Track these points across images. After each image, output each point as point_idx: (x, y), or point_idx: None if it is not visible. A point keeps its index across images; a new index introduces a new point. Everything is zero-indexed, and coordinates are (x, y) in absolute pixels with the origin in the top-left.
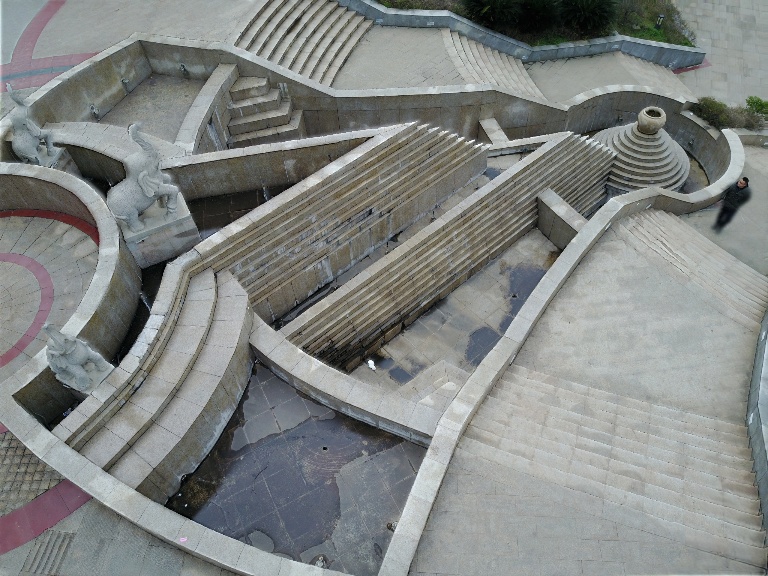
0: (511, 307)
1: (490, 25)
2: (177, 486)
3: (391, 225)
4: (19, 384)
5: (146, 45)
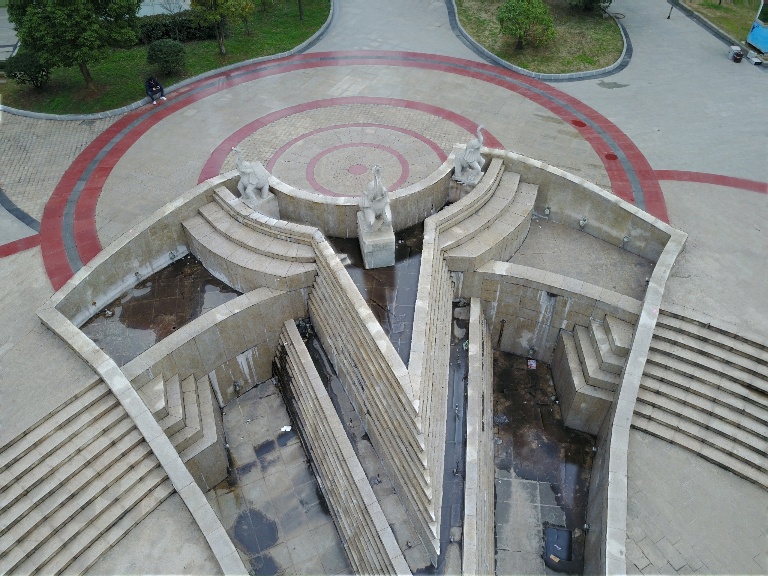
0: None
1: None
2: None
3: None
4: None
5: None
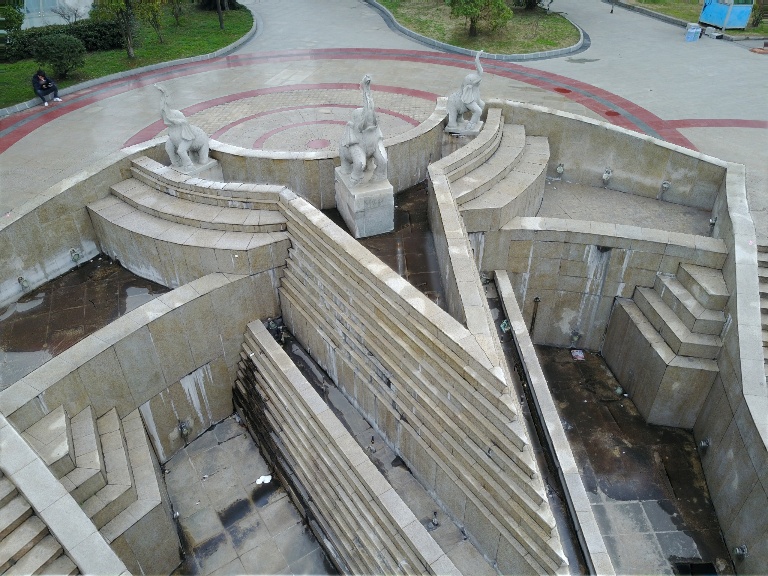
0: None
1: None
2: None
3: (400, 439)
4: None
5: None
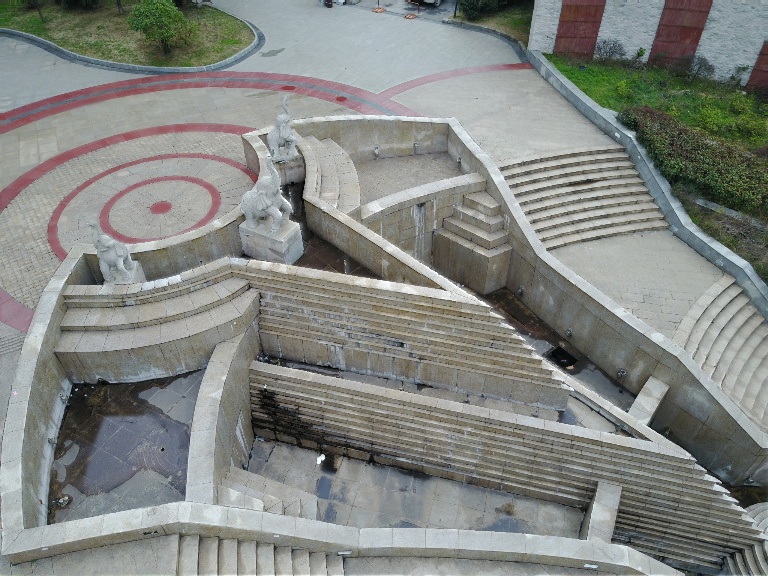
0: None
1: None
2: (95, 380)
3: (420, 372)
4: (93, 251)
5: (450, 130)
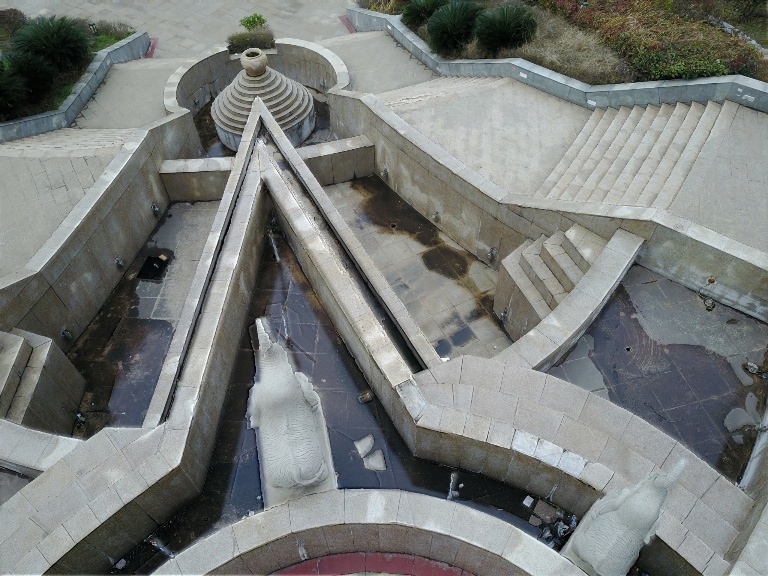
0: (406, 231)
1: (8, 116)
2: None
3: None
4: None
5: None
